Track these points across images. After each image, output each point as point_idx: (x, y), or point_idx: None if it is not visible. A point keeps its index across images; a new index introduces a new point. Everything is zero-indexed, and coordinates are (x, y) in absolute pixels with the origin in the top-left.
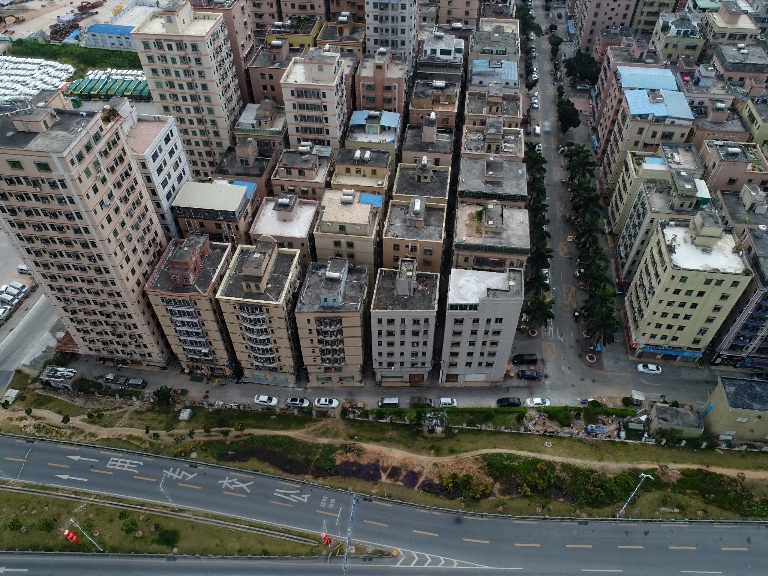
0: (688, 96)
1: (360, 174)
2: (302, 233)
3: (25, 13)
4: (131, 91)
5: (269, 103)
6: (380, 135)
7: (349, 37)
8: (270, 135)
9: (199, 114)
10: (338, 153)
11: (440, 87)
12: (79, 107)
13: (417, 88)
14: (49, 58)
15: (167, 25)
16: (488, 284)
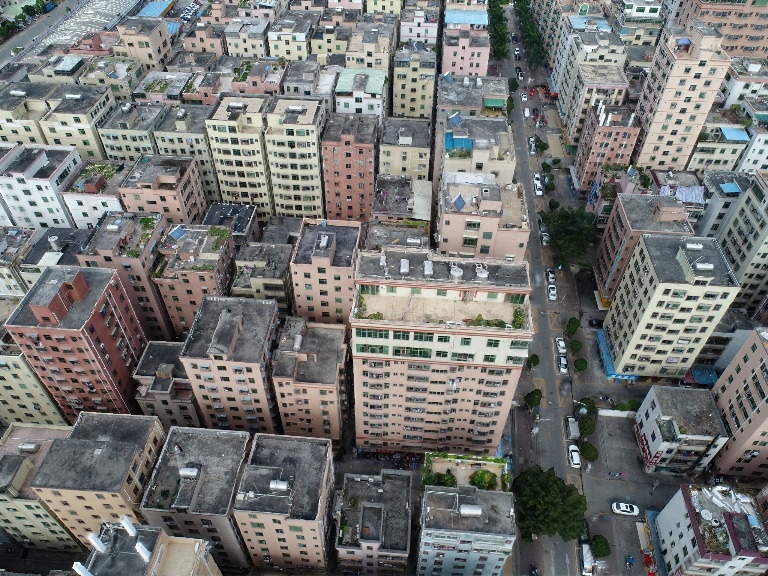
0: None
1: None
2: None
3: None
4: None
5: None
6: None
7: None
8: None
9: None
10: None
11: None
12: None
13: None
14: None
15: None
16: None
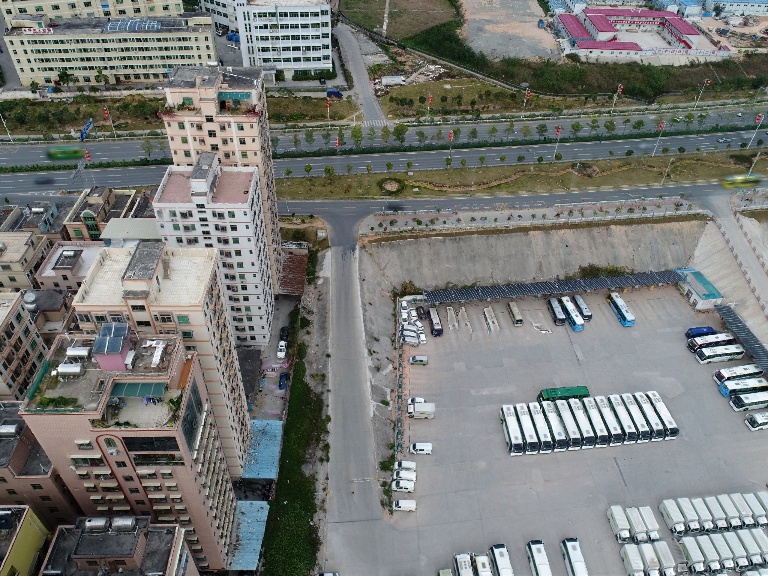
0: None
1: None
2: None
3: None
4: None
5: None
6: None
7: None
8: None
9: None
10: None
11: None
12: None
13: None
14: None
15: None
16: None
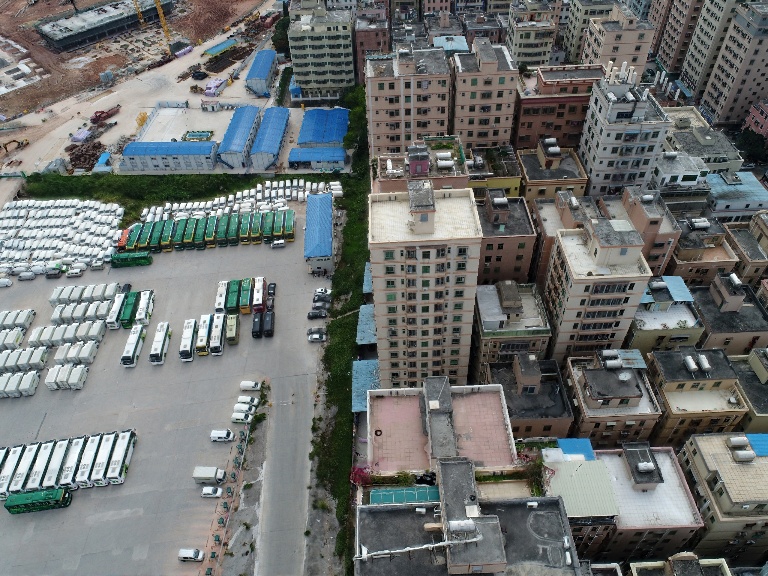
0: None
1: (696, 388)
2: (684, 512)
3: (24, 132)
4: (213, 235)
5: (513, 286)
6: (669, 312)
7: (559, 170)
8: (533, 335)
9: (440, 324)
10: (657, 361)
11: (704, 228)
12: (150, 264)
13: None
14: (81, 194)
15: (418, 224)
16: None
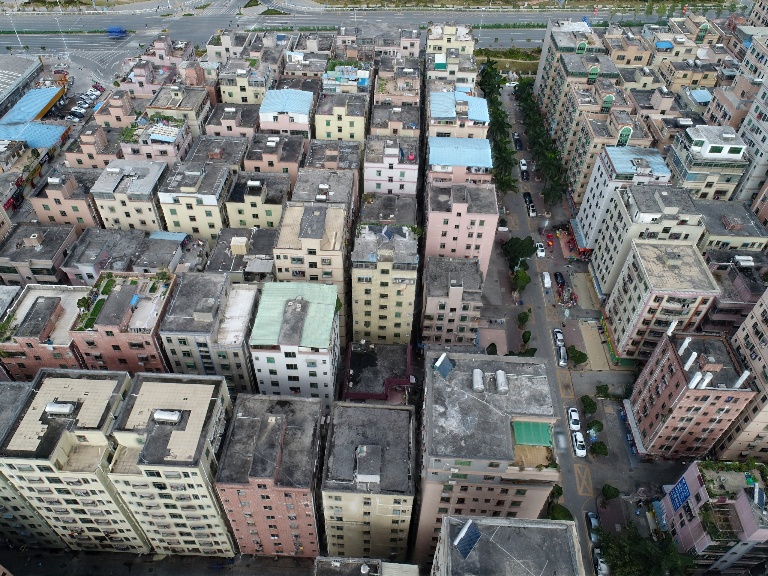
0: (415, 142)
1: None
2: None
3: None
4: None
5: None
6: None
7: None
8: None
9: None
10: None
11: None
12: None
13: (704, 123)
14: None
15: None
16: (569, 27)
